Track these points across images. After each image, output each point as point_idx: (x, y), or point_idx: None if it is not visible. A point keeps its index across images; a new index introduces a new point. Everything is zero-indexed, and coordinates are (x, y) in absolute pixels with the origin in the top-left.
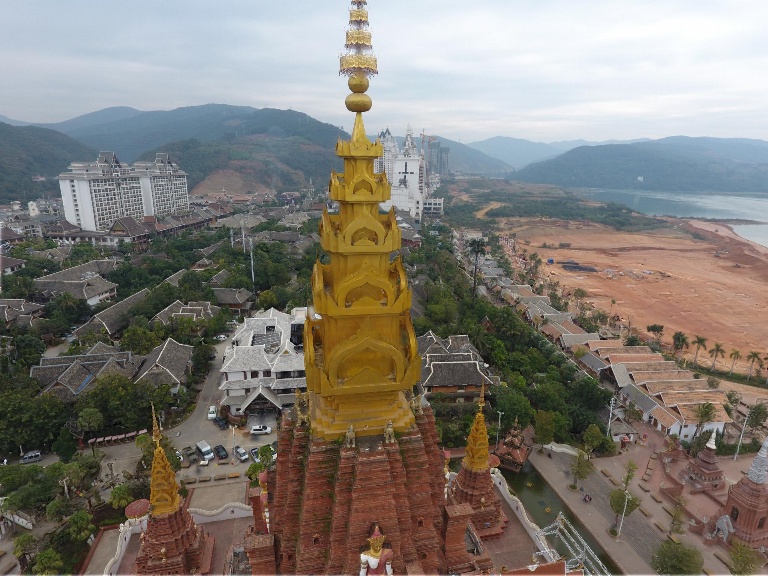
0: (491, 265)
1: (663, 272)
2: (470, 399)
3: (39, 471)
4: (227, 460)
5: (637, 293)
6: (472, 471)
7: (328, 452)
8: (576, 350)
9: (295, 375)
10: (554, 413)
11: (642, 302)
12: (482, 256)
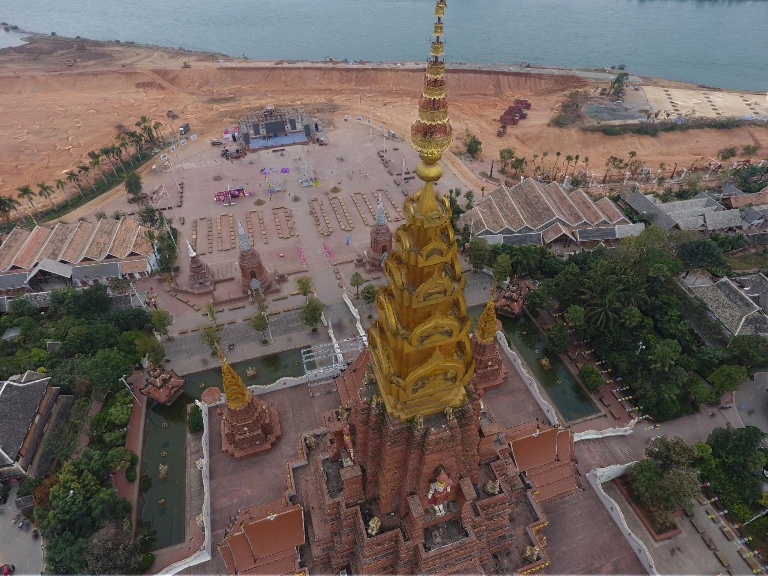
0: None
1: None
2: None
3: None
4: None
5: None
6: (250, 402)
7: None
8: None
9: None
10: (126, 335)
11: None
12: None
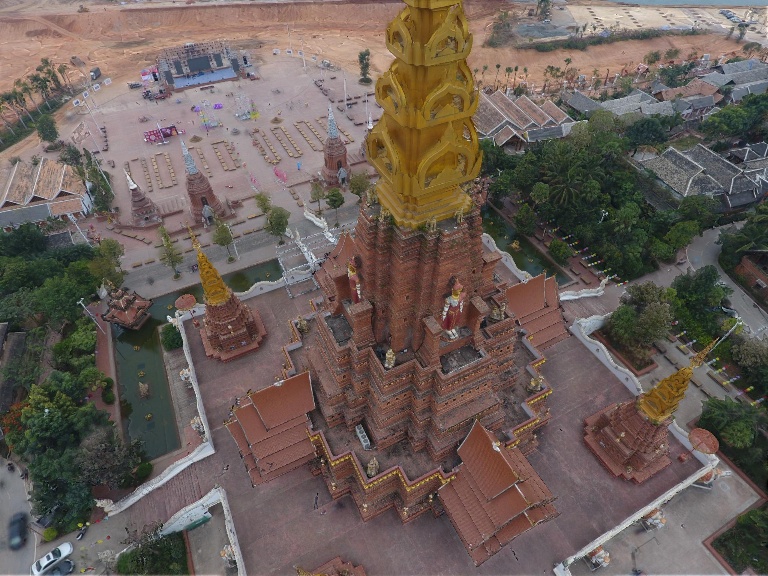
0: None
1: None
2: None
3: None
4: None
5: None
6: (231, 298)
7: None
8: None
9: None
10: (75, 265)
11: None
12: None
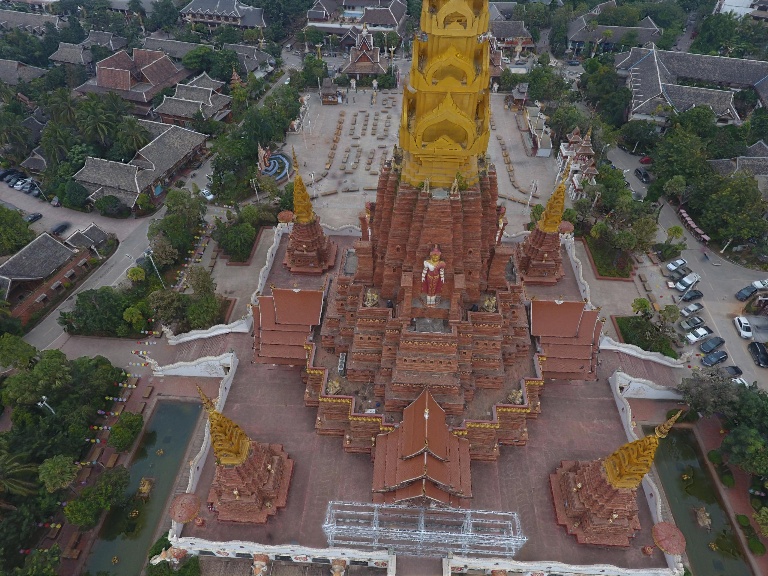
0: None
1: None
2: None
3: (619, 186)
4: None
5: None
6: None
7: None
8: None
9: None
10: None
11: None
12: None
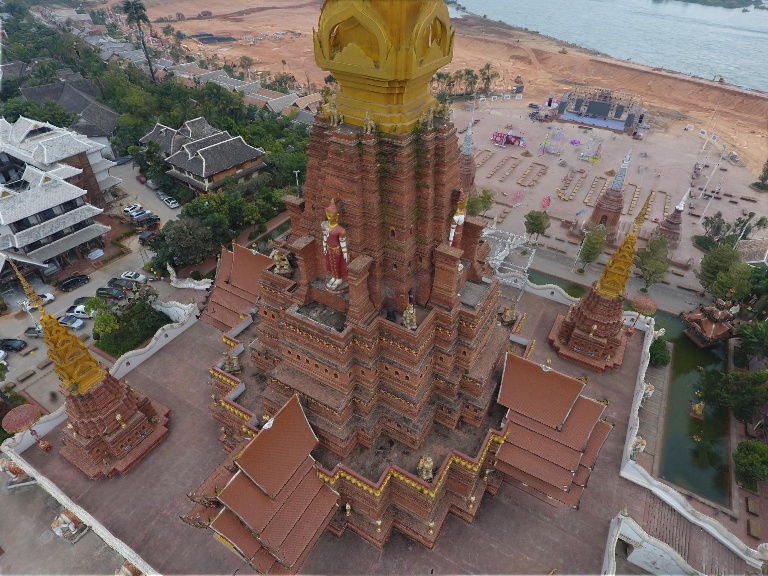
0: (126, 48)
1: (293, 30)
2: None
3: None
4: (32, 346)
5: (285, 55)
6: None
7: (411, 144)
8: (288, 113)
9: (38, 220)
10: None
11: (295, 62)
12: (146, 24)
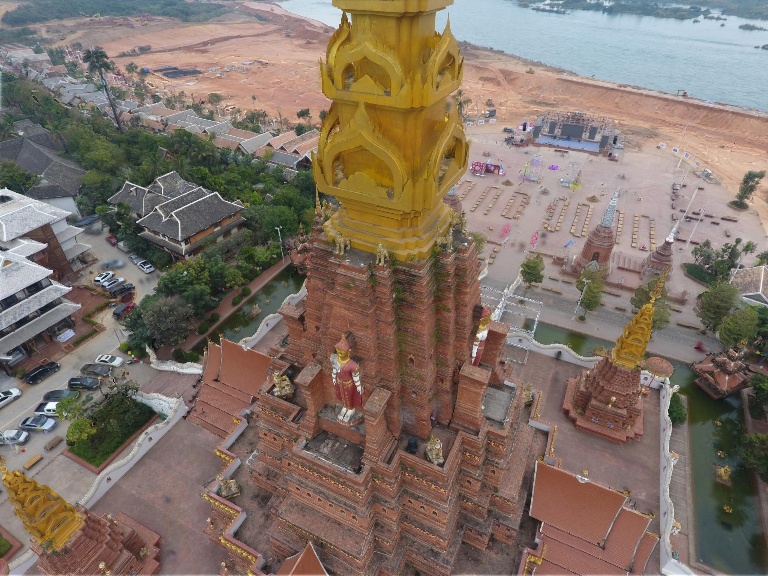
0: (87, 89)
1: (259, 60)
2: (228, 233)
3: None
4: None
5: (254, 86)
6: None
7: None
8: (262, 154)
9: None
10: None
11: (264, 94)
12: (108, 72)
